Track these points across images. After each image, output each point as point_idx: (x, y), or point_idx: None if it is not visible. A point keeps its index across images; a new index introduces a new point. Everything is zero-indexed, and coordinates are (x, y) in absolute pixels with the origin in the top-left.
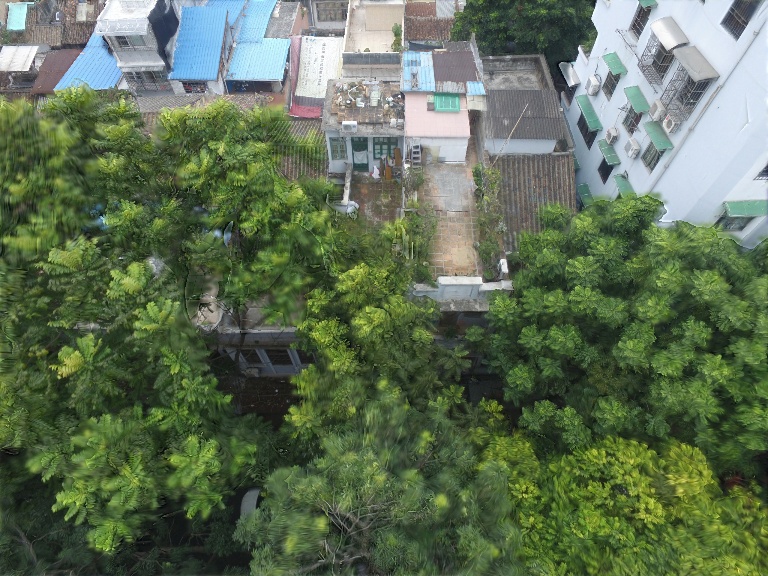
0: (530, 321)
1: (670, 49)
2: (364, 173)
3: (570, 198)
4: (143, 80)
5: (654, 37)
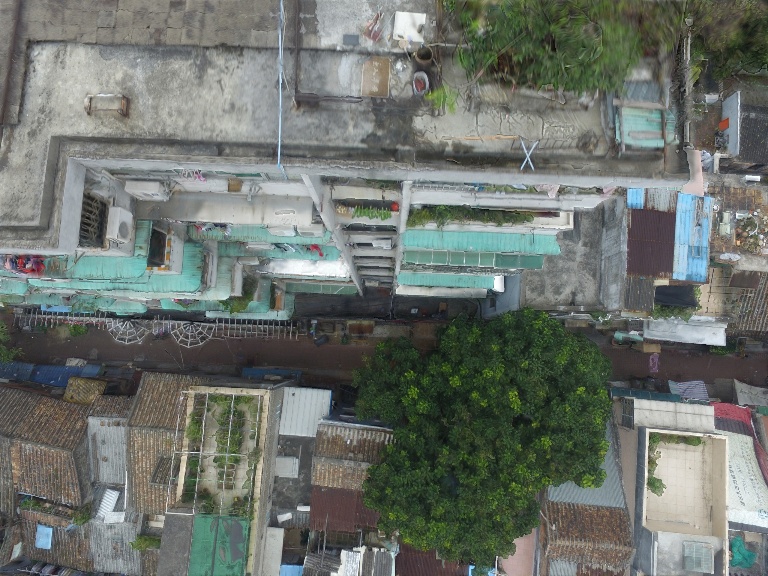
0: None
1: None
2: None
3: None
4: None
5: None
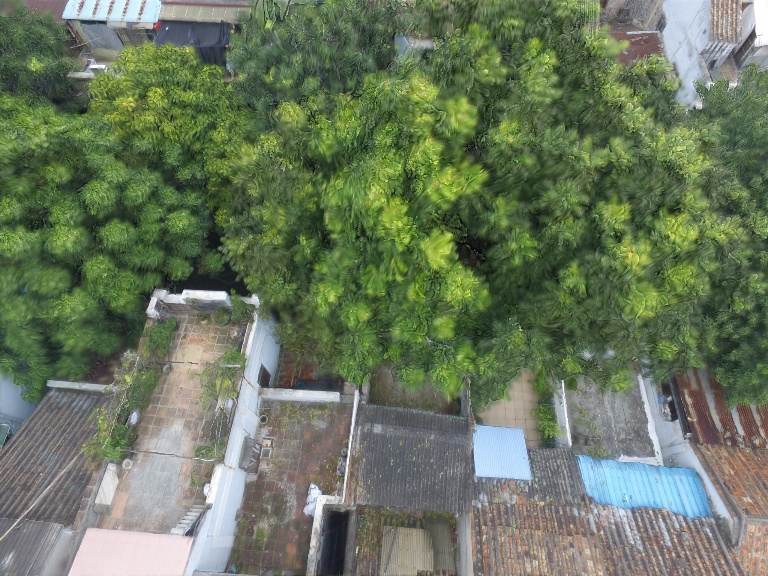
0: None
1: None
2: None
3: (5, 454)
4: None
5: None
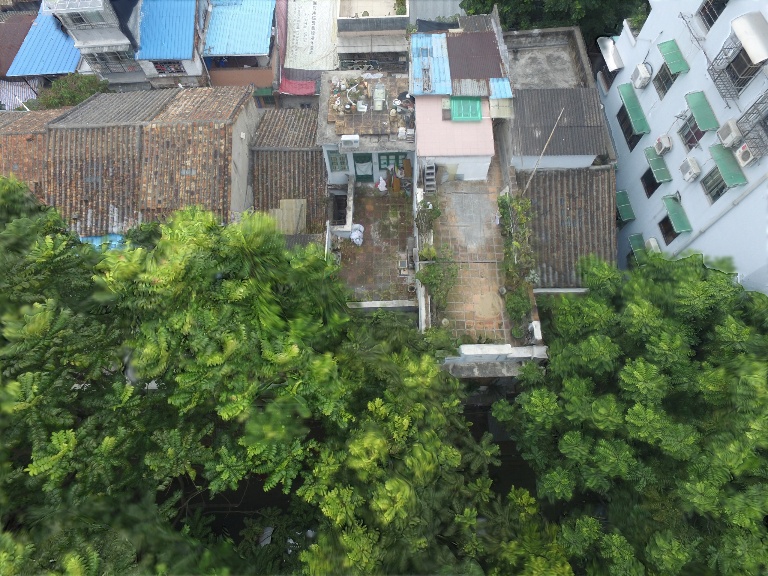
0: (573, 425)
1: (758, 63)
2: (368, 184)
3: (609, 222)
4: (107, 62)
5: (735, 39)
